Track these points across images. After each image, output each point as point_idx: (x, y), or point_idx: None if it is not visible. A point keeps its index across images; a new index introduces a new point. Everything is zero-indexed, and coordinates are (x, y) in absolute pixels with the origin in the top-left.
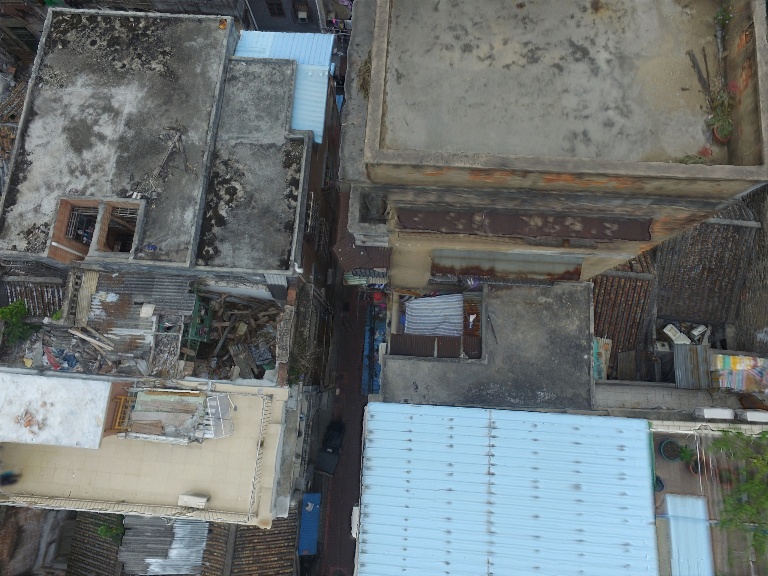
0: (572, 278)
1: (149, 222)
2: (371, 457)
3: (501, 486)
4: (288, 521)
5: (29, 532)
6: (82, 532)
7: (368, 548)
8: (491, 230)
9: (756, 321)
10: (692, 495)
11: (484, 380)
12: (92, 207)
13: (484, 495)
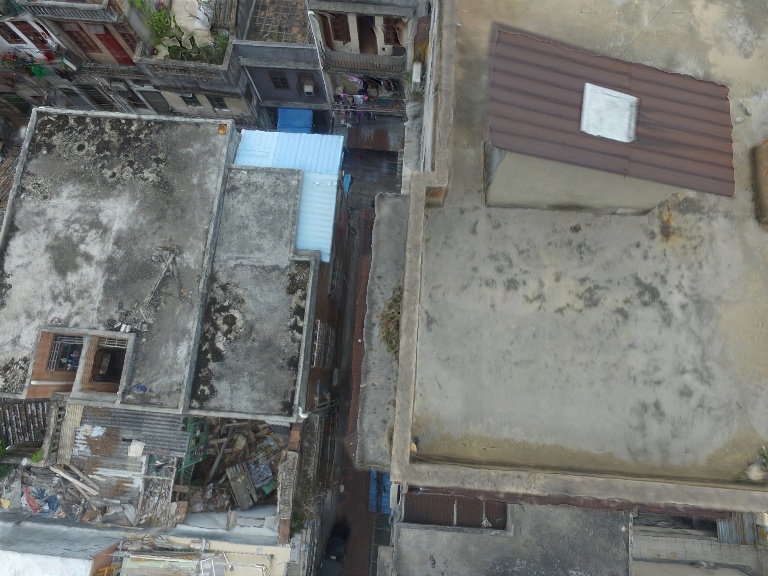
0: None
1: (139, 358)
2: None
3: None
4: None
5: None
6: None
7: None
8: (538, 501)
9: None
10: None
11: (509, 555)
12: (77, 336)
13: None
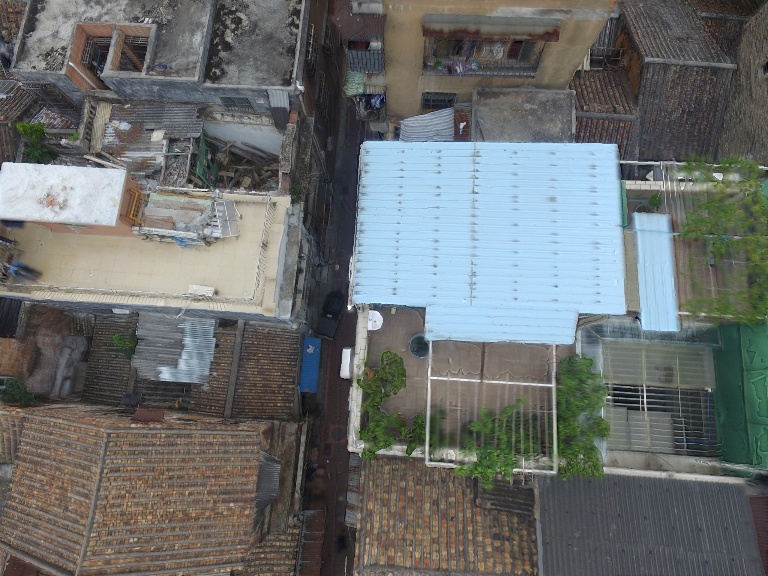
0: (551, 39)
1: (160, 45)
2: (366, 184)
3: (484, 202)
4: (290, 342)
5: (46, 358)
6: (96, 359)
7: (363, 257)
8: None
9: (732, 156)
10: (658, 213)
11: None
12: (106, 37)
13: (469, 210)
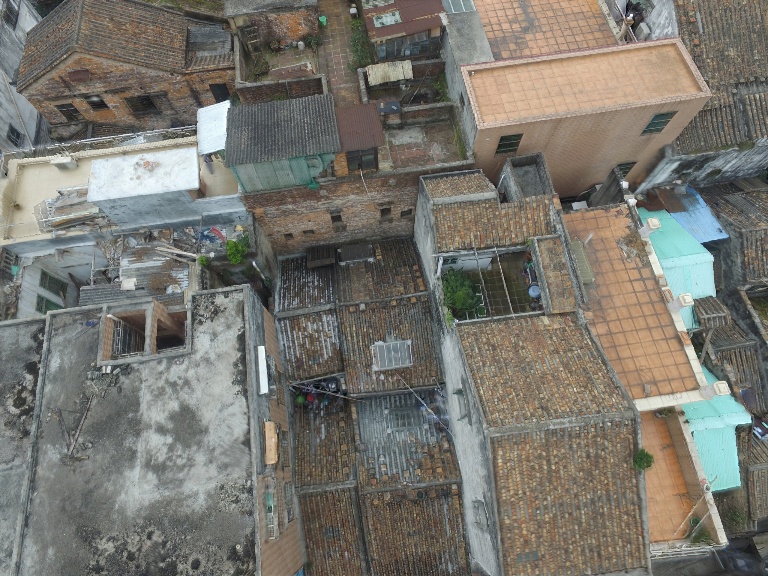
0: None
1: (96, 347)
2: None
3: None
4: None
5: None
6: None
7: None
8: None
9: None
10: None
11: None
12: None
13: None
